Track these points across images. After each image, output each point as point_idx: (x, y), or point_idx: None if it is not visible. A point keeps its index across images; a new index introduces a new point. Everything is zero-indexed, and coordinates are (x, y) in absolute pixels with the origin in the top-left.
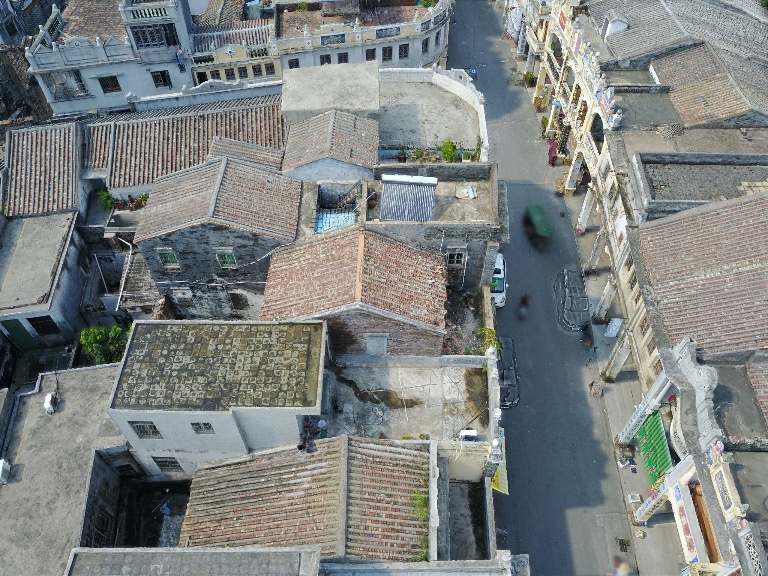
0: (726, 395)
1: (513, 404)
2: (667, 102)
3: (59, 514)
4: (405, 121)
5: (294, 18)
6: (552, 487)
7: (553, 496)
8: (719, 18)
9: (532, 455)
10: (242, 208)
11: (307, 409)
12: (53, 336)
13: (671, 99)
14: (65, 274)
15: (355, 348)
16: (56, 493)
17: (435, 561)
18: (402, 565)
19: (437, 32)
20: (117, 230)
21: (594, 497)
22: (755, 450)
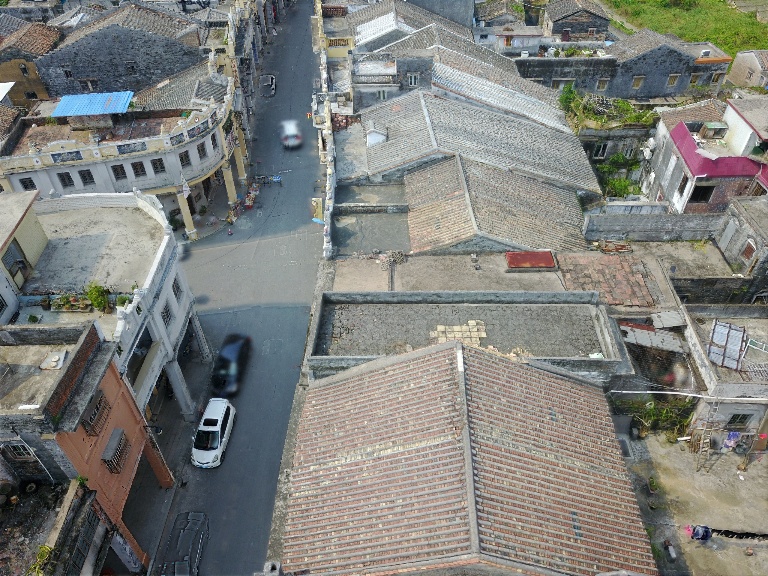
0: None
1: None
2: (403, 223)
3: None
4: (81, 256)
5: (39, 133)
6: None
7: None
8: (493, 126)
9: None
10: None
11: None
12: None
13: (408, 220)
14: None
15: None
16: None
17: None
18: None
19: (201, 144)
20: None
21: None
22: None
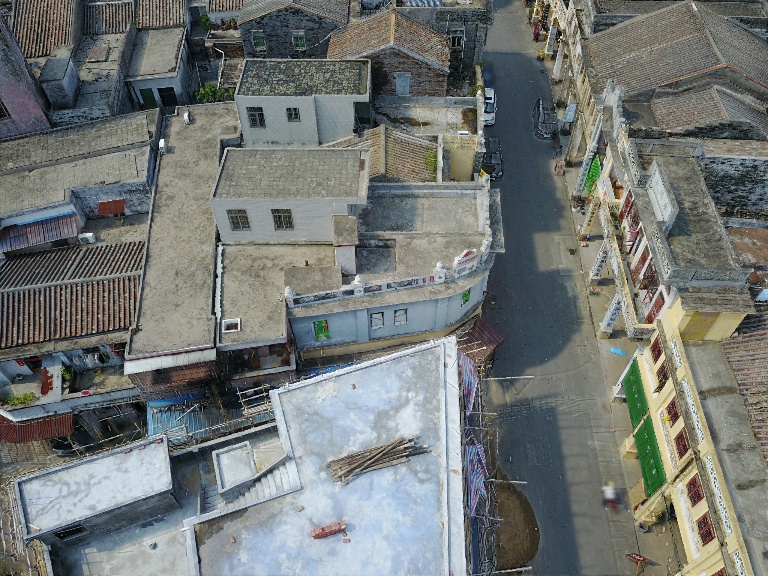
0: (635, 116)
1: (498, 176)
2: None
3: (202, 166)
4: None
5: None
6: (524, 222)
7: (524, 227)
8: None
9: (511, 206)
10: (311, 2)
11: (361, 95)
12: (172, 108)
13: None
14: (182, 63)
15: (388, 89)
16: (198, 158)
17: (441, 182)
18: (420, 183)
19: None
20: (214, 41)
21: (554, 227)
22: (649, 137)
